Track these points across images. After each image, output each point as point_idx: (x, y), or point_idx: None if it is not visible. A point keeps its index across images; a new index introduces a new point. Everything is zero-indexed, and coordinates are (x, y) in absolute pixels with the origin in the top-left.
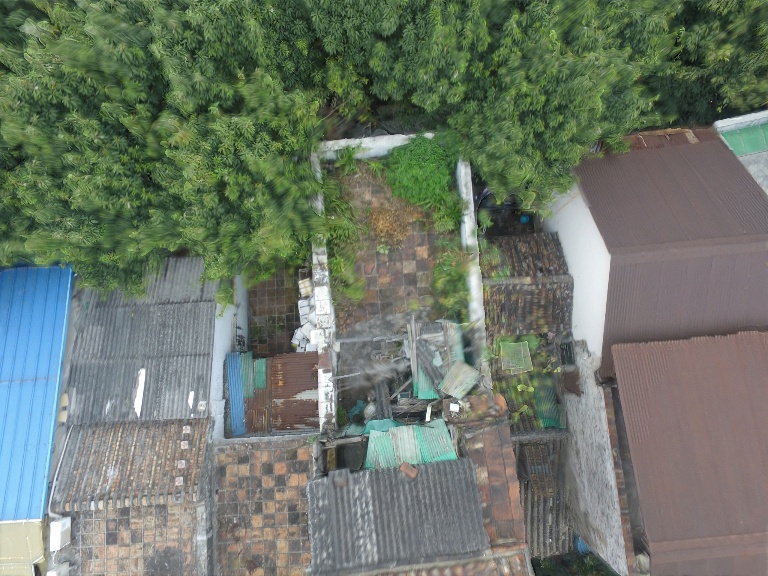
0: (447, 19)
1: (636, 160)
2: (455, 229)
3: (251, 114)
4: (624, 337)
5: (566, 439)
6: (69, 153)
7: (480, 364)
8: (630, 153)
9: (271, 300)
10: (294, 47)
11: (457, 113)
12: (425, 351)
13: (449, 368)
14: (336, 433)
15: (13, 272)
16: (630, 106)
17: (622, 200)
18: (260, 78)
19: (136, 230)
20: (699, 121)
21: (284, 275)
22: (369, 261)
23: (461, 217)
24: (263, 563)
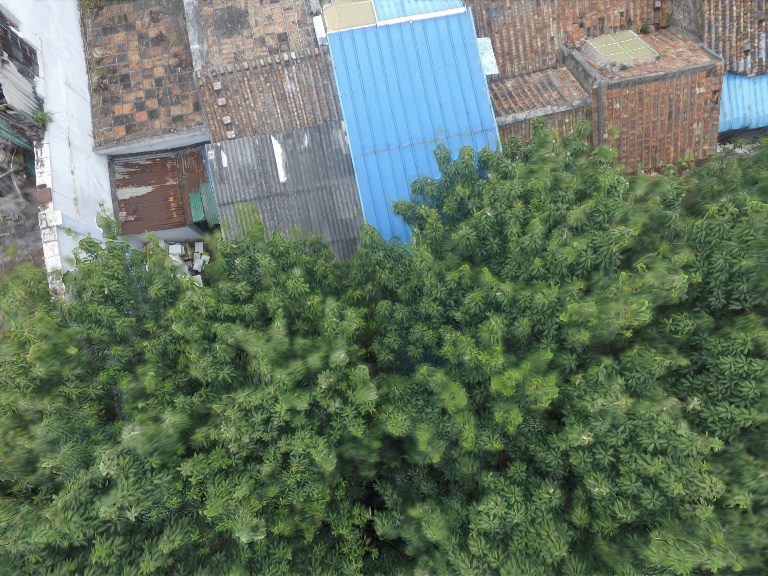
0: None
1: None
2: None
3: (23, 424)
4: None
5: None
6: None
7: None
8: None
9: None
10: None
11: None
12: None
13: None
14: (9, 124)
15: None
16: None
17: None
18: None
19: None
20: None
21: None
22: None
23: None
24: (150, 41)
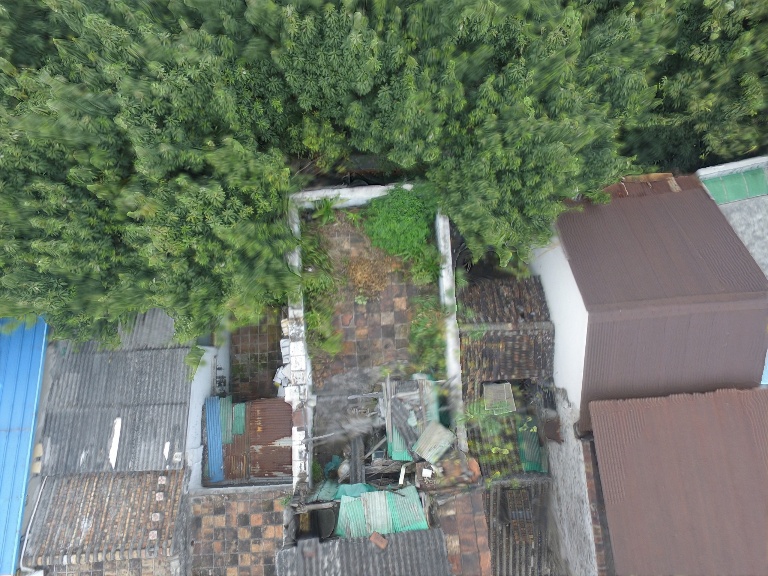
0: (421, 82)
1: (617, 209)
2: (433, 281)
3: (222, 178)
4: (602, 392)
5: (547, 483)
6: (37, 217)
7: (455, 424)
8: (612, 201)
9: (253, 337)
10: (268, 105)
11: (435, 168)
12: (400, 410)
13: (423, 429)
14: (308, 496)
15: None
16: (608, 164)
17: (602, 253)
18: (230, 144)
19: (107, 289)
20: (683, 163)
21: None
22: (347, 312)
23: (439, 270)
24: None
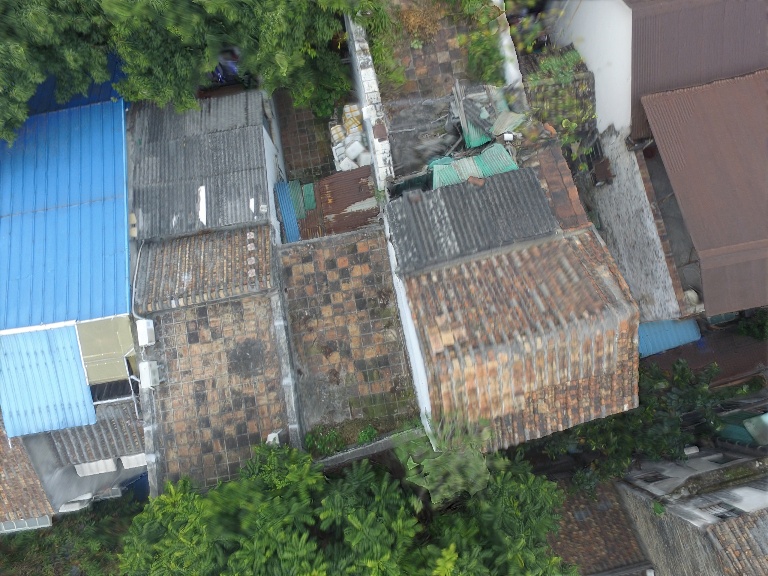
0: None
1: None
2: None
3: None
4: None
5: None
6: None
7: (524, 113)
8: None
9: (305, 154)
10: None
11: None
12: (472, 108)
13: (497, 117)
14: None
15: (67, 112)
16: None
17: None
18: None
19: None
20: None
21: (314, 131)
22: (405, 57)
23: None
24: (338, 347)
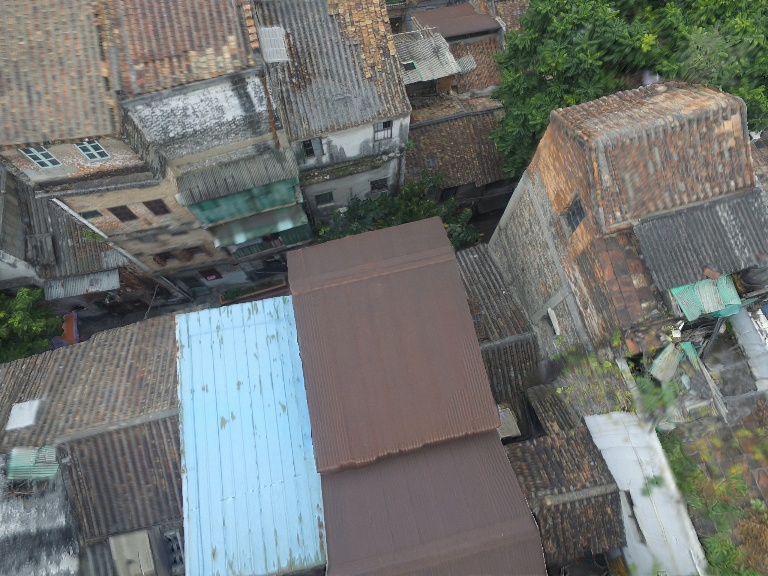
0: None
1: None
2: None
3: None
4: (479, 439)
5: None
6: None
7: (645, 382)
8: None
9: None
10: None
11: None
12: (701, 388)
13: None
14: (759, 300)
15: None
16: None
17: None
18: None
19: None
20: None
21: None
22: (767, 487)
23: None
24: None
